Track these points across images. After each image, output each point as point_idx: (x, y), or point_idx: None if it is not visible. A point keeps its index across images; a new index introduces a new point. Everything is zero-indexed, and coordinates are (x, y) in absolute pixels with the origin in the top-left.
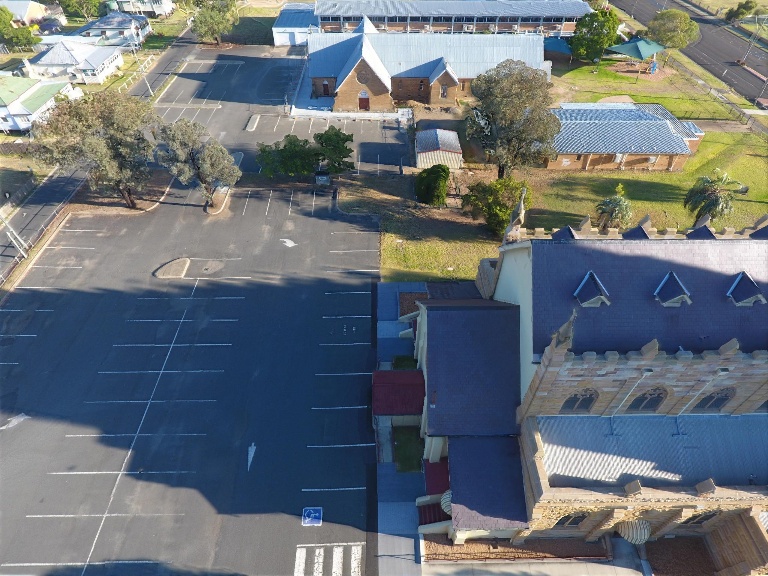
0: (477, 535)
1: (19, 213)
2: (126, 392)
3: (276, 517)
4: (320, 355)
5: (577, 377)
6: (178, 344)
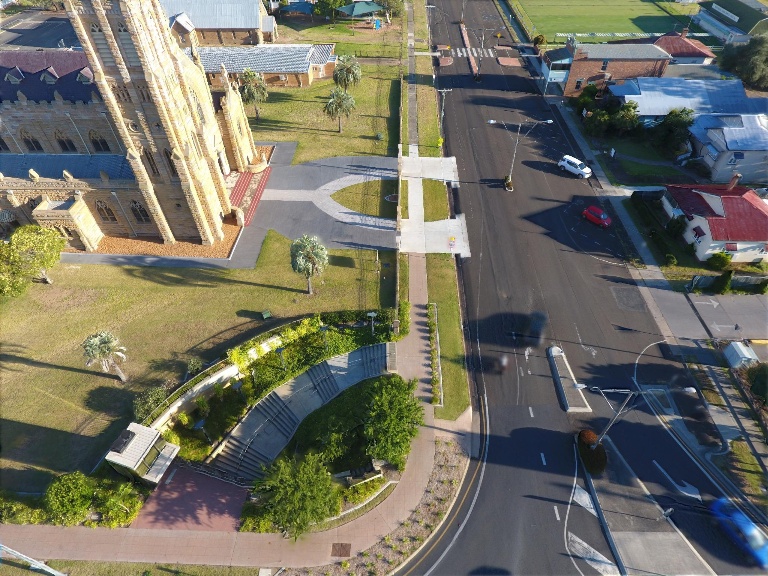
0: None
1: None
2: None
3: None
4: None
5: None
6: None
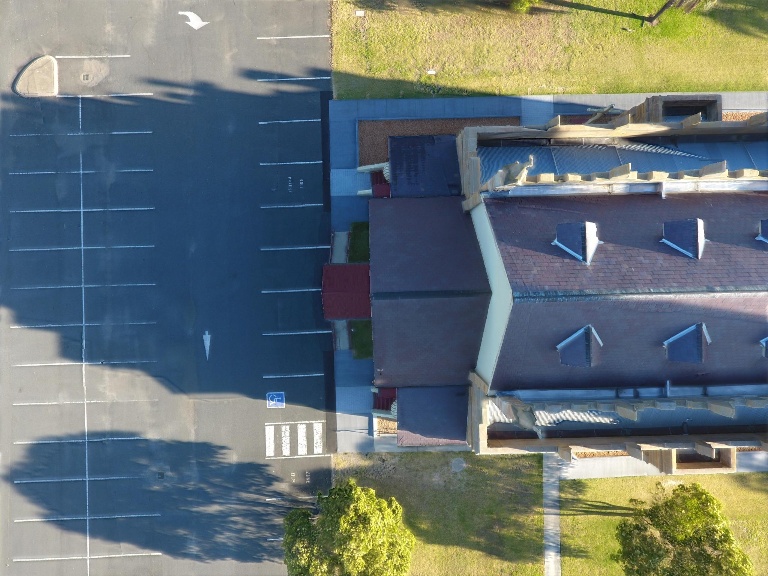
0: None
1: None
2: (52, 276)
3: (243, 401)
4: (263, 223)
5: None
6: (88, 209)
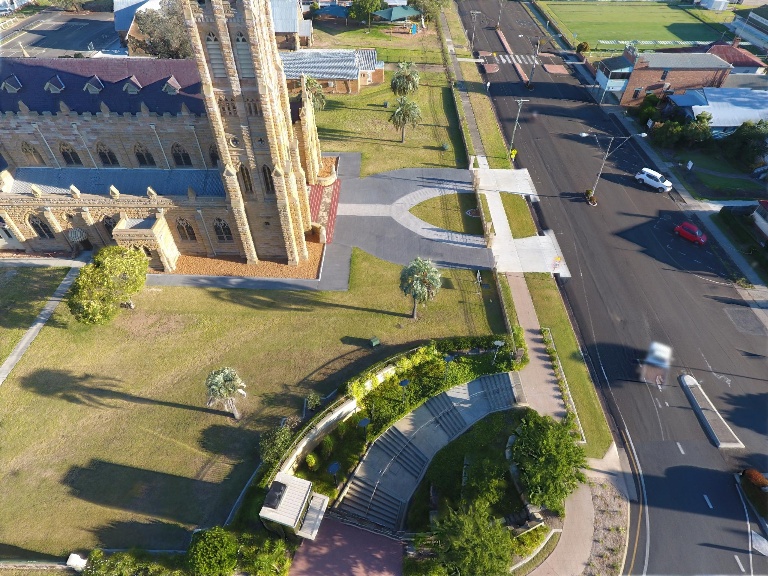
0: (2, 245)
1: None
2: None
3: None
4: None
5: (4, 130)
6: None
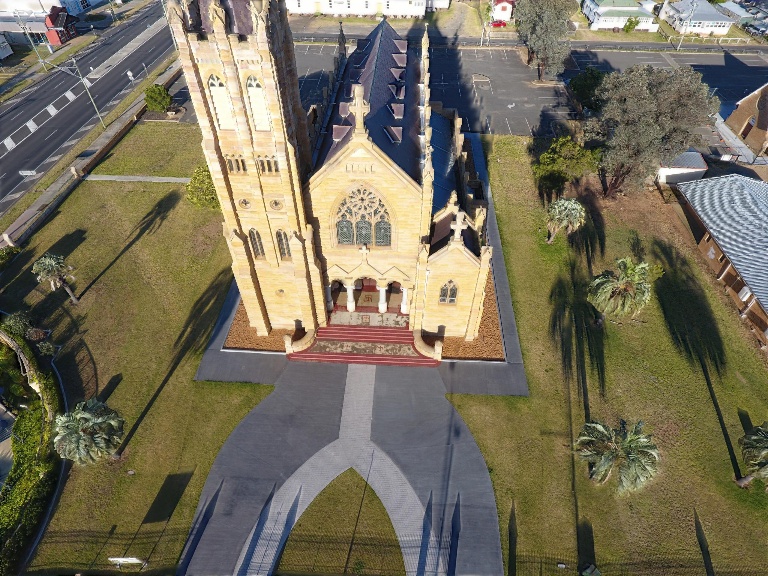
0: None
1: (515, 40)
2: None
3: None
4: None
5: None
6: None
